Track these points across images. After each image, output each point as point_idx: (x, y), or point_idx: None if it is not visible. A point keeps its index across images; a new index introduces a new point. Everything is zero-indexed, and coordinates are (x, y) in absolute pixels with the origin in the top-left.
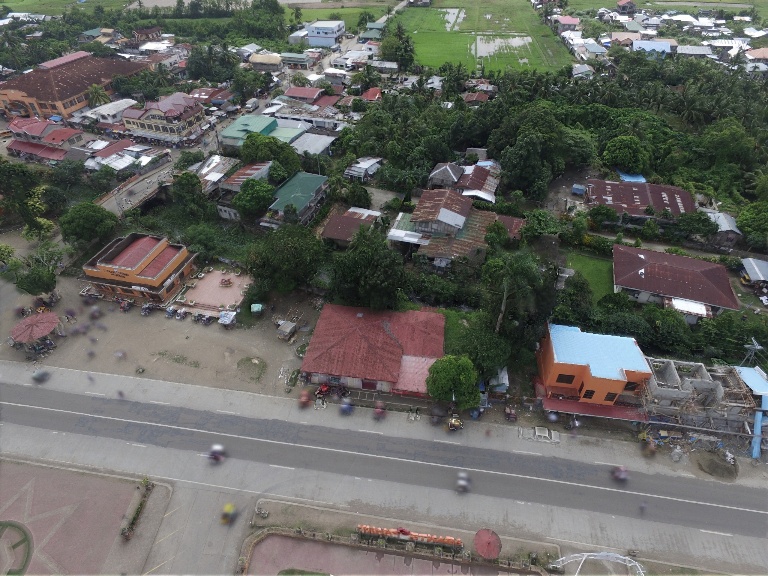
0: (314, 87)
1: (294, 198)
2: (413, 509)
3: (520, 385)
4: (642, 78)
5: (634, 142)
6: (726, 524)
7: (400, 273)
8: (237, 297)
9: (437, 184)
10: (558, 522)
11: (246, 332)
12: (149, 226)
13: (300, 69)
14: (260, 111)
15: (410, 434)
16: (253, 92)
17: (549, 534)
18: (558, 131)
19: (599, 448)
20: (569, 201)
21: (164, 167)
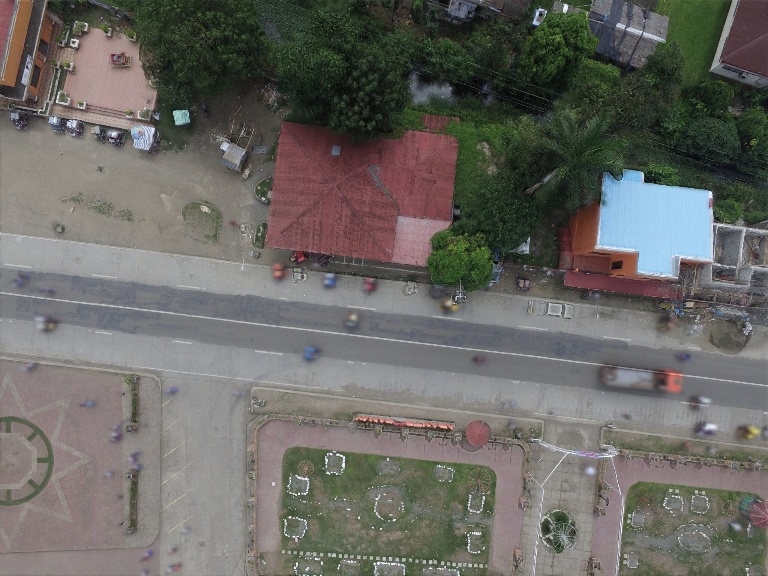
0: None
1: None
2: (408, 391)
3: (542, 240)
4: None
5: None
6: (708, 396)
7: (396, 101)
8: (147, 91)
9: None
10: (548, 399)
11: (179, 157)
12: None
13: None
14: None
15: (406, 310)
16: None
17: (537, 410)
18: None
19: (612, 321)
20: None
21: None
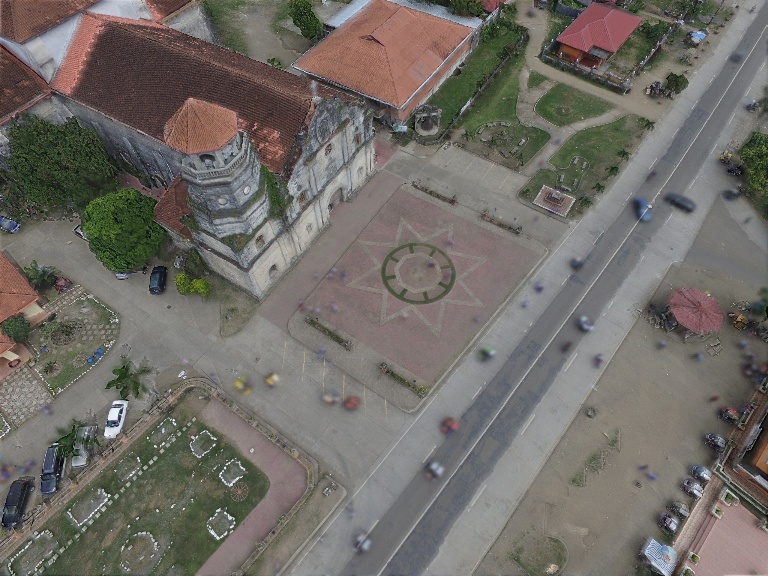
0: None
1: None
2: None
3: None
4: None
5: None
6: None
7: None
8: None
9: None
10: None
11: None
12: None
13: None
14: None
15: None
16: None
17: None
18: None
19: None
20: None
21: None
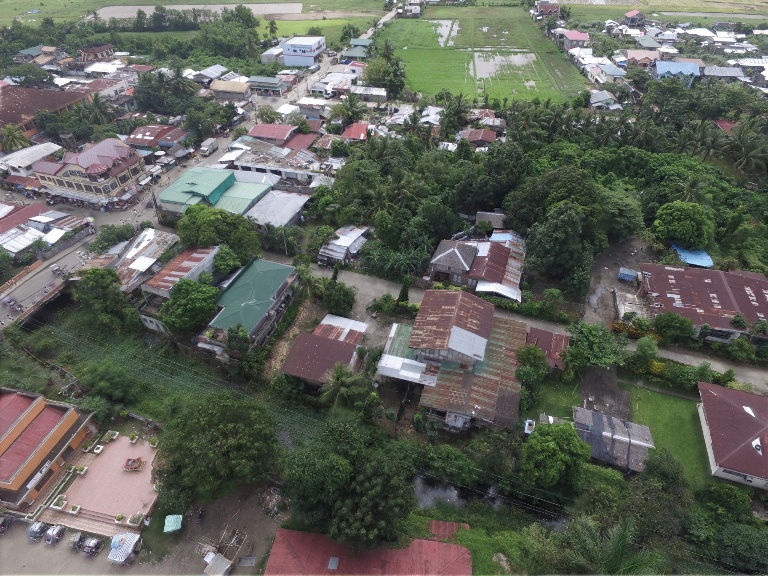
0: (285, 123)
1: (245, 309)
2: None
3: None
4: (679, 112)
5: (698, 212)
6: None
7: (399, 507)
8: (148, 494)
9: (442, 271)
10: None
11: (154, 570)
12: (38, 352)
13: (272, 96)
14: (216, 158)
15: None
16: (211, 130)
17: None
18: (600, 199)
19: None
20: (618, 295)
21: (82, 243)
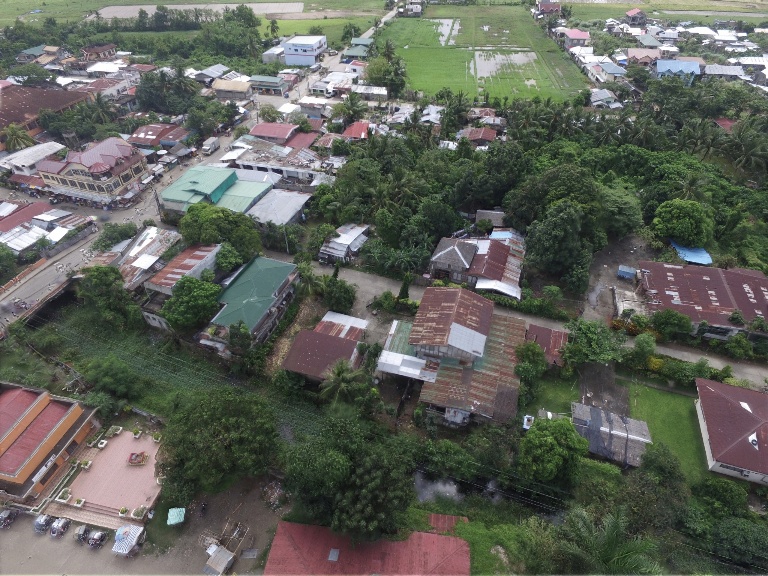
0: (287, 122)
1: (247, 306)
2: None
3: None
4: (679, 110)
5: (697, 210)
6: None
7: (398, 499)
8: (151, 488)
9: (442, 269)
10: None
11: (158, 562)
12: (42, 349)
13: (273, 95)
14: (218, 157)
15: None
16: (212, 129)
17: None
18: (599, 197)
19: None
20: (617, 292)
21: (85, 242)
